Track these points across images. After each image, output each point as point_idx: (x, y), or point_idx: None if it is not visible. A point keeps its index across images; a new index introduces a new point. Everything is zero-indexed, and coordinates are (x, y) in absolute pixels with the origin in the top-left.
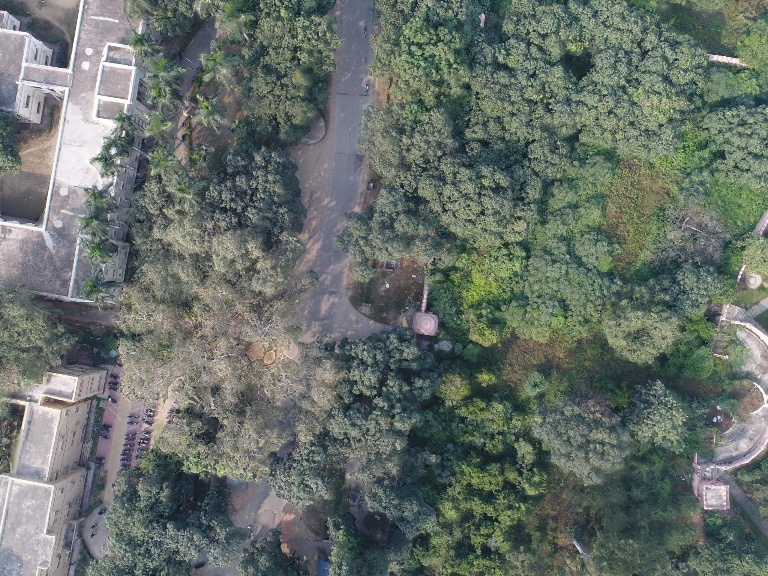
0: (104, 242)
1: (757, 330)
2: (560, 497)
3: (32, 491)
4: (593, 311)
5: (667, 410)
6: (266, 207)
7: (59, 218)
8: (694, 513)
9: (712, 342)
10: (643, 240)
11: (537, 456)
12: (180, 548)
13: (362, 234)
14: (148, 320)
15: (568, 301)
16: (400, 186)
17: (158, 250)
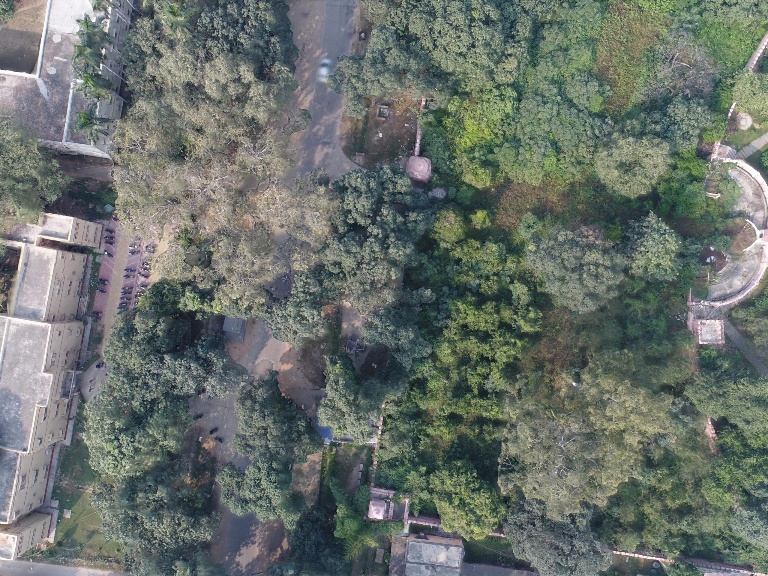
0: (97, 76)
1: (748, 166)
2: (556, 340)
3: (29, 331)
4: (585, 152)
5: (660, 235)
6: (258, 35)
7: (52, 65)
8: (689, 345)
9: (704, 181)
10: (634, 82)
11: (532, 299)
12: (177, 379)
13: (354, 73)
14: (142, 150)
15: (560, 143)
16: (391, 25)
17: (151, 91)
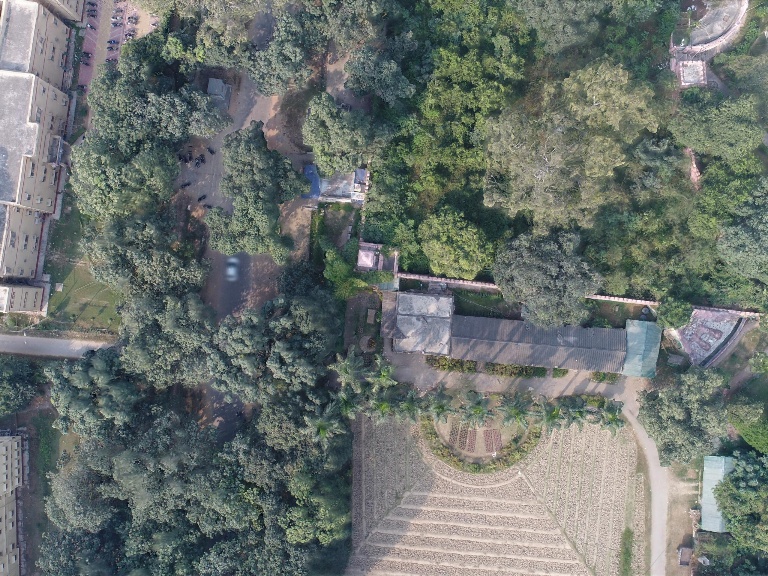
0: None
1: None
2: (540, 95)
3: (13, 83)
4: None
5: None
6: None
7: None
8: (671, 83)
9: None
10: None
11: (515, 53)
12: (162, 116)
13: None
14: None
15: None
16: None
17: None
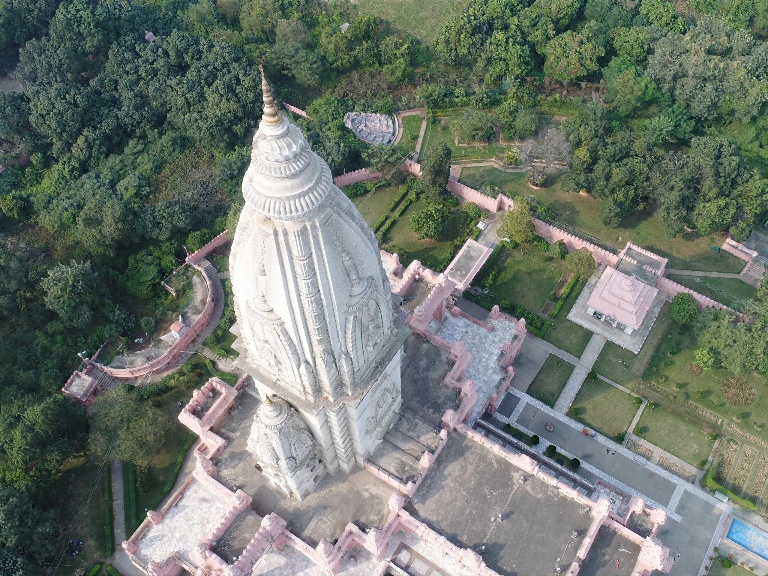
0: None
1: (205, 275)
2: None
3: None
4: None
5: None
6: None
7: None
8: (45, 381)
9: (170, 275)
10: None
11: None
12: None
13: None
14: None
15: None
16: None
17: None
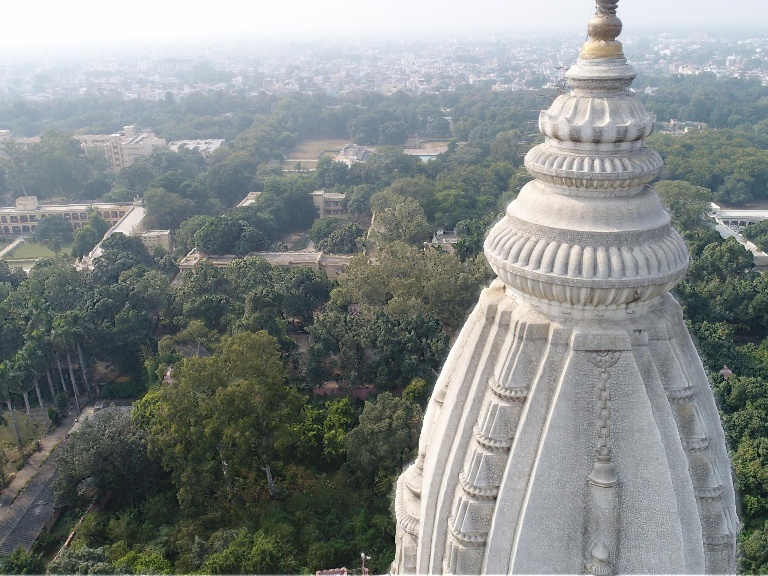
0: None
1: None
2: None
3: None
4: None
5: None
6: None
7: None
8: (314, 549)
9: None
10: None
11: None
12: None
13: None
14: None
15: None
16: None
17: None
